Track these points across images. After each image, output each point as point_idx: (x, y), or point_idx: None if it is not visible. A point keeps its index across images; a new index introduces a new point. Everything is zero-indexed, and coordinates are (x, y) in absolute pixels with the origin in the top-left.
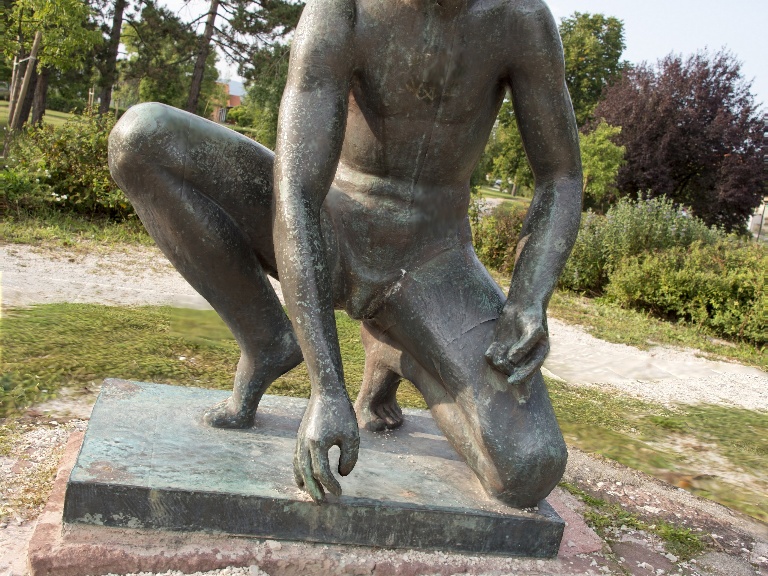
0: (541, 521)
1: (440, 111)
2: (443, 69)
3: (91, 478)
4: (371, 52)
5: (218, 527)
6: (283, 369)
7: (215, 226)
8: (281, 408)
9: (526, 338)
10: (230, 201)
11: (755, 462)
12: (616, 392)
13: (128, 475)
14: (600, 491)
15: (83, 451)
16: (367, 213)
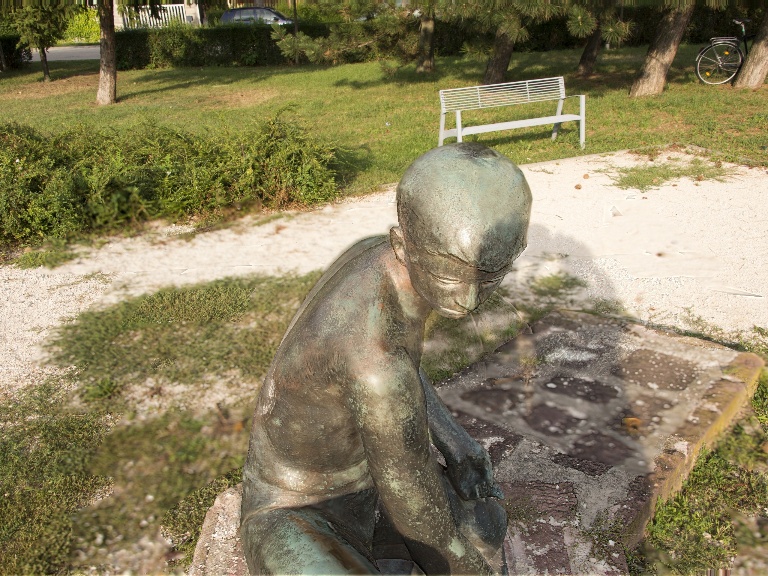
0: None
1: None
2: None
3: None
4: None
5: None
6: None
7: None
8: None
9: None
10: None
11: (194, 372)
12: (4, 393)
13: None
14: None
15: None
16: (374, 491)
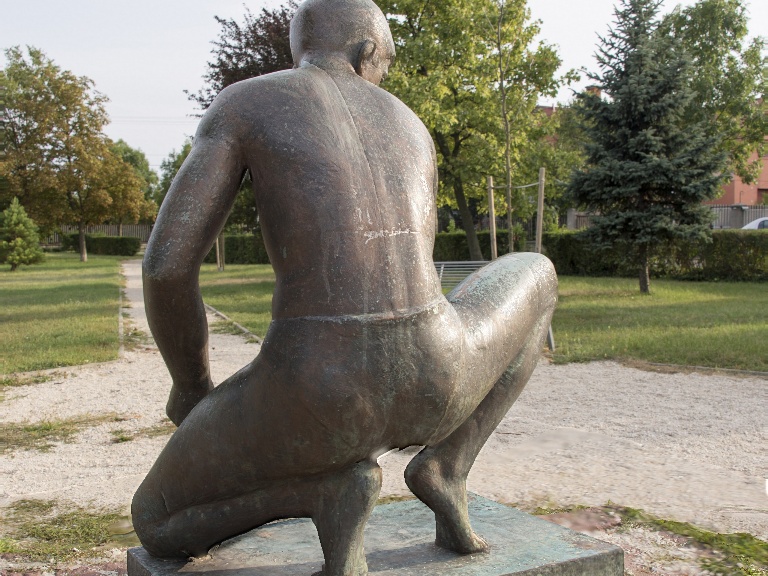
0: None
1: None
2: None
3: None
4: None
5: None
6: None
7: None
8: (443, 569)
9: None
10: None
11: None
12: None
13: None
14: None
15: None
16: None
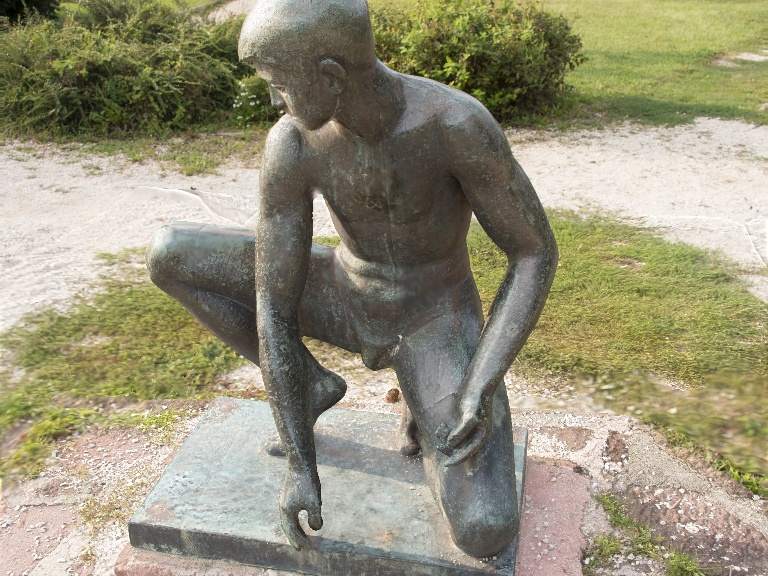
0: (490, 573)
1: (391, 216)
2: (382, 185)
3: (144, 519)
4: (318, 176)
5: (232, 558)
6: (321, 409)
7: (230, 318)
8: (342, 427)
9: (460, 427)
10: (241, 295)
11: None
12: None
13: (172, 516)
14: (648, 503)
15: (155, 488)
16: (359, 292)
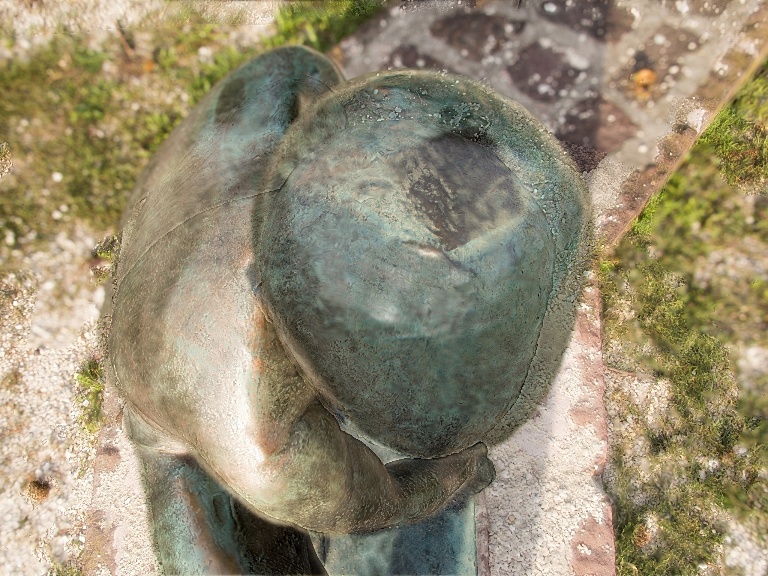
0: None
1: None
2: None
3: None
4: None
5: None
6: None
7: None
8: None
9: None
10: None
11: None
12: None
13: None
14: None
15: None
16: None
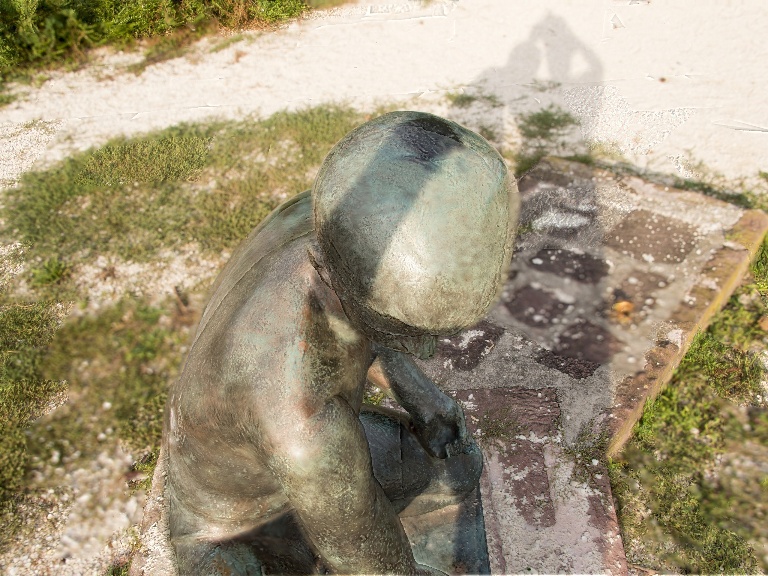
0: None
1: None
2: None
3: None
4: None
5: None
6: None
7: None
8: None
9: None
10: None
11: (149, 248)
12: None
13: None
14: None
15: None
16: None
